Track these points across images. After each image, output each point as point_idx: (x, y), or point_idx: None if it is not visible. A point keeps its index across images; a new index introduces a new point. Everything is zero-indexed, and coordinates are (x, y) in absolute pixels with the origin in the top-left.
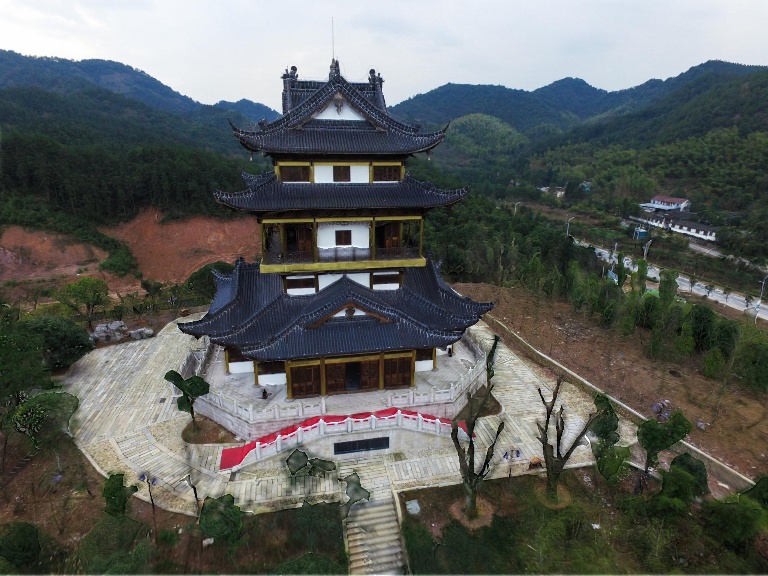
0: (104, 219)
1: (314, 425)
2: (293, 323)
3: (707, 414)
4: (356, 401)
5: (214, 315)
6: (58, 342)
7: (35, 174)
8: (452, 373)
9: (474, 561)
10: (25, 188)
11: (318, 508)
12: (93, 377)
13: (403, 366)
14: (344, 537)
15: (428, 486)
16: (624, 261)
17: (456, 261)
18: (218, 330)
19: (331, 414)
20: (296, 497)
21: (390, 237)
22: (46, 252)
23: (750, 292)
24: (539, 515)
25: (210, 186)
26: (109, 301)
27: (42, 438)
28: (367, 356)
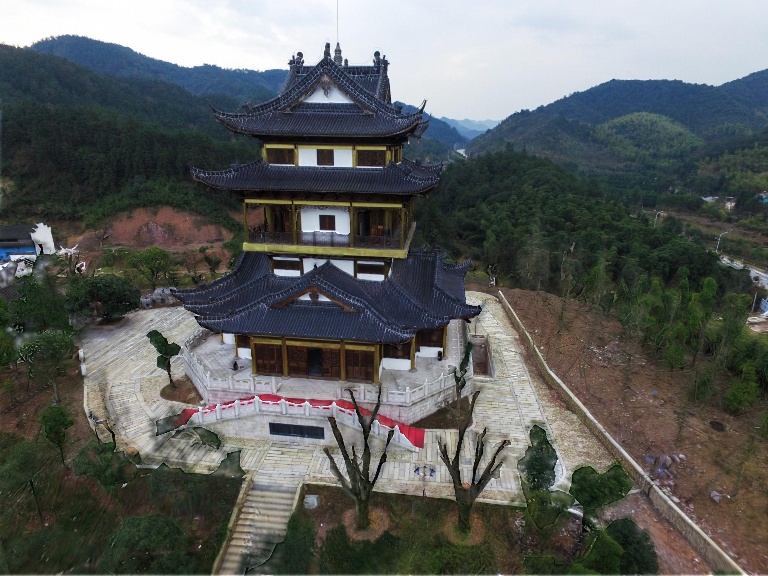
0: (236, 205)
1: (250, 400)
2: (258, 300)
3: (733, 484)
4: (312, 387)
5: (209, 286)
6: (107, 297)
7: (188, 164)
8: (428, 377)
9: (305, 568)
10: (181, 176)
11: (170, 472)
12: (133, 331)
13: (366, 360)
14: (233, 513)
15: (336, 485)
16: None
17: (559, 270)
18: None
19: (280, 394)
20: (216, 465)
21: (375, 225)
22: (186, 230)
23: None
24: (412, 543)
25: None
26: None
27: (35, 368)
28: (327, 343)
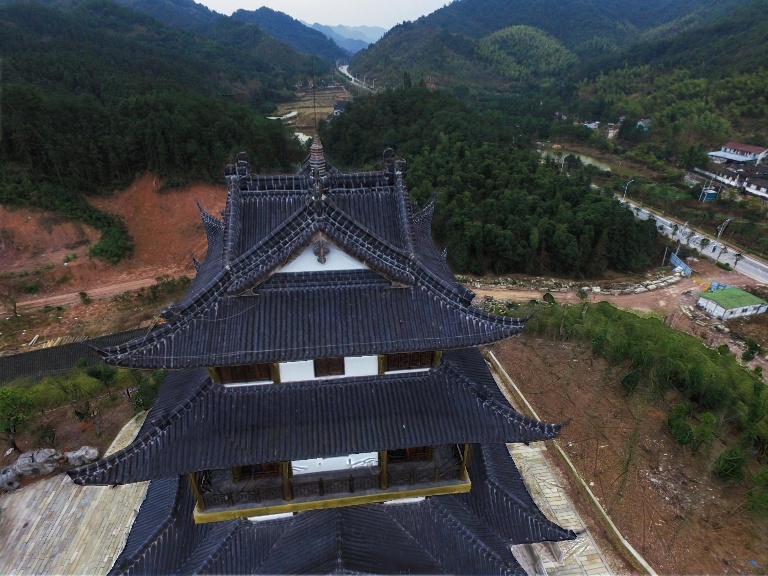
0: (96, 188)
1: None
2: None
3: None
4: None
5: (134, 558)
6: None
7: (13, 138)
8: None
9: None
10: (4, 154)
11: None
12: None
13: None
14: None
15: None
16: (691, 240)
17: (493, 243)
18: None
19: None
20: None
21: None
22: (31, 234)
23: None
24: None
25: (212, 147)
26: (99, 299)
27: None
28: None
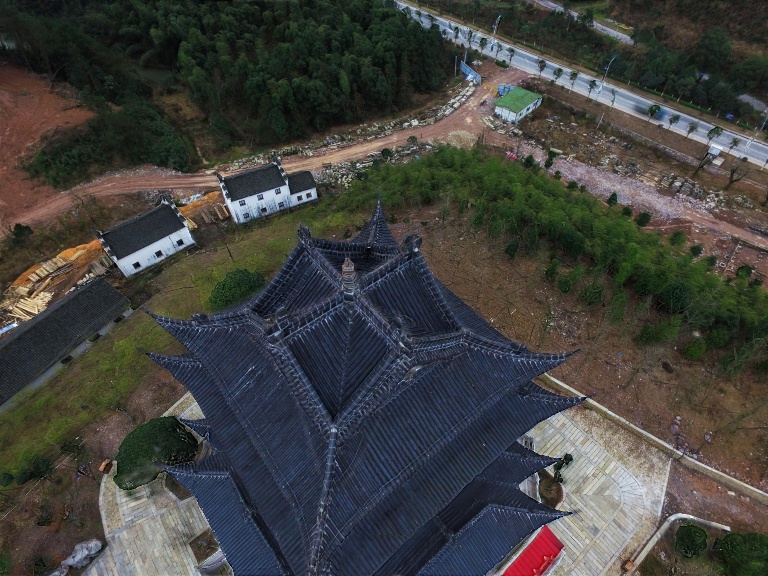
0: None
1: None
2: None
3: (707, 420)
4: None
5: None
6: None
7: None
8: None
9: None
10: None
11: None
12: None
13: None
14: None
15: None
16: (471, 41)
17: (306, 99)
18: None
19: None
20: None
21: None
22: None
23: (583, 61)
24: None
25: None
26: None
27: None
28: None
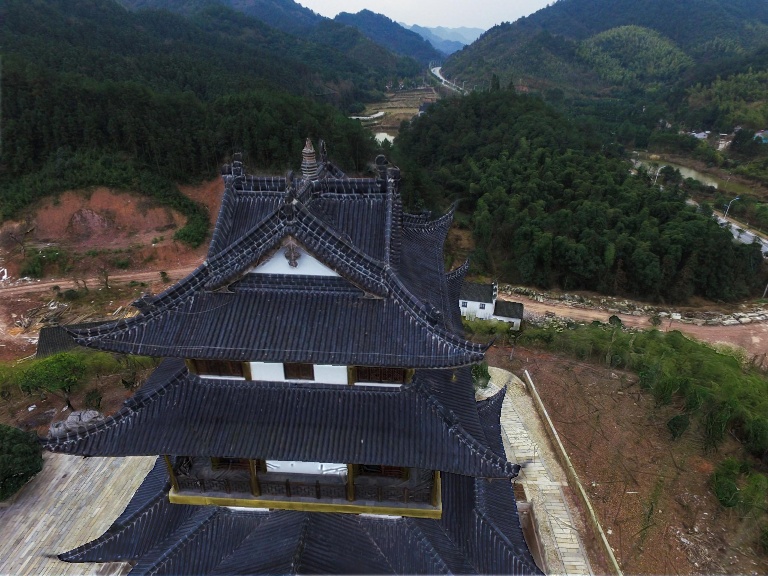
0: (188, 177)
1: None
2: None
3: None
4: None
5: (125, 524)
6: None
7: (123, 130)
8: None
9: None
10: (116, 144)
11: None
12: (36, 510)
13: None
14: None
15: None
16: None
17: (563, 257)
18: (124, 553)
19: None
20: None
21: None
22: (129, 216)
23: None
24: None
25: (292, 144)
26: (177, 279)
27: None
28: None
